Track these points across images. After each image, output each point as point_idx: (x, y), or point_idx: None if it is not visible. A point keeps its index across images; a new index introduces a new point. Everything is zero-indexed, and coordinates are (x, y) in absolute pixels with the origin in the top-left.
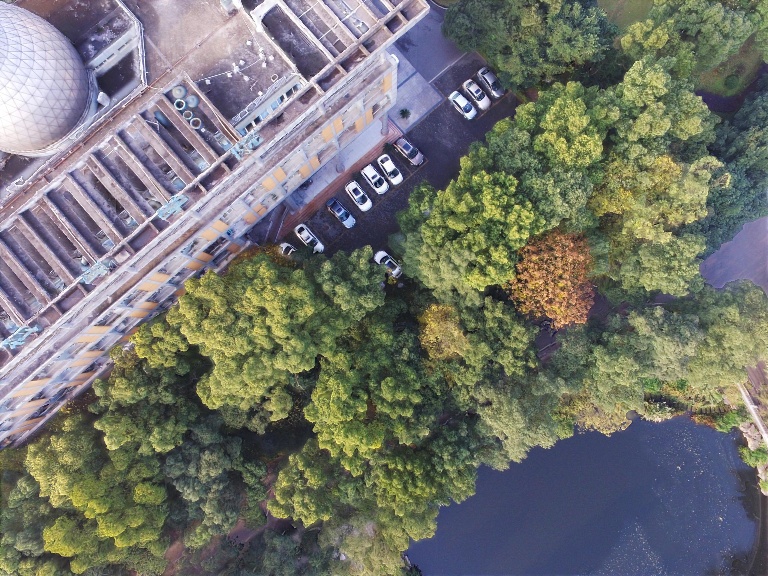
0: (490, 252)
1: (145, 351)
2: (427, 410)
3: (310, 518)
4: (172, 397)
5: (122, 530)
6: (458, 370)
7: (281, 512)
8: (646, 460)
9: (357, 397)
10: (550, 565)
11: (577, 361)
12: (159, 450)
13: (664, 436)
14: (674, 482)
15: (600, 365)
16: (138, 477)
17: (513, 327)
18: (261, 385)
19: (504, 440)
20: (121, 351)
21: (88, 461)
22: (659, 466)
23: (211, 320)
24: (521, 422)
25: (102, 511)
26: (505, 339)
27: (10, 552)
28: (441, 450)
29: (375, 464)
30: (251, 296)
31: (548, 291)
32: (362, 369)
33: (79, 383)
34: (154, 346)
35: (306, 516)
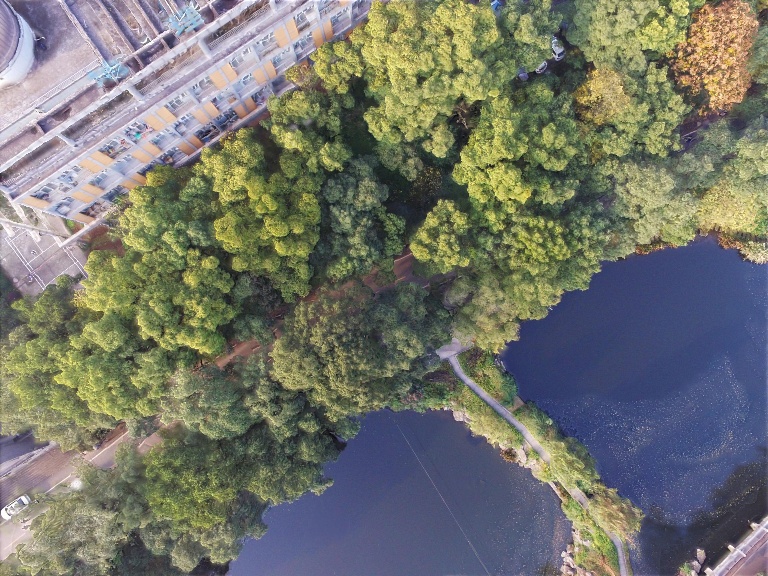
0: (670, 5)
1: (324, 68)
2: (571, 178)
3: (454, 257)
4: (340, 122)
5: (287, 232)
6: (610, 137)
7: (426, 250)
8: (743, 299)
9: (519, 139)
10: (638, 386)
11: (718, 153)
12: (328, 162)
13: (764, 278)
14: (767, 323)
15: (745, 152)
16: (303, 189)
17: (671, 98)
18: (435, 108)
19: (639, 219)
20: (299, 69)
21: (258, 168)
22: (755, 306)
23: (401, 31)
24: (672, 182)
25: (273, 207)
26: (661, 110)
27: (182, 236)
28: (579, 218)
29: (515, 224)
30: (442, 12)
31: (717, 56)
32: (521, 120)
33: (242, 114)
34: (333, 65)
35: (450, 256)
